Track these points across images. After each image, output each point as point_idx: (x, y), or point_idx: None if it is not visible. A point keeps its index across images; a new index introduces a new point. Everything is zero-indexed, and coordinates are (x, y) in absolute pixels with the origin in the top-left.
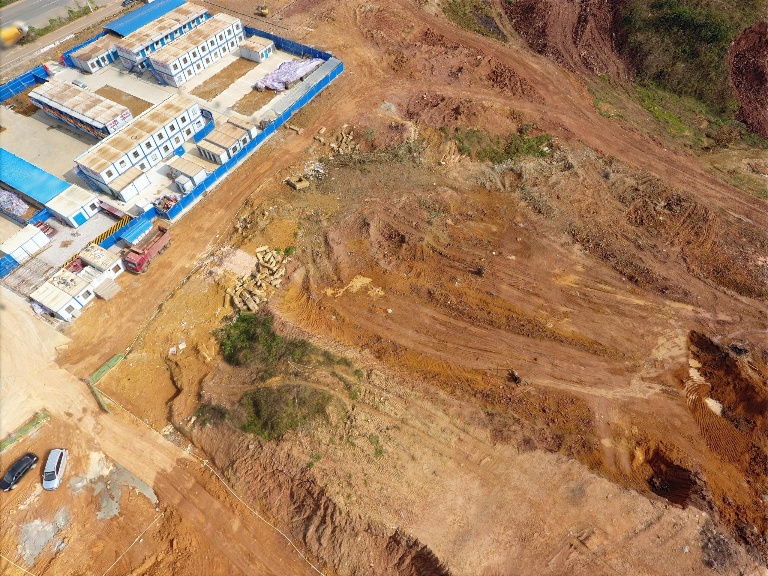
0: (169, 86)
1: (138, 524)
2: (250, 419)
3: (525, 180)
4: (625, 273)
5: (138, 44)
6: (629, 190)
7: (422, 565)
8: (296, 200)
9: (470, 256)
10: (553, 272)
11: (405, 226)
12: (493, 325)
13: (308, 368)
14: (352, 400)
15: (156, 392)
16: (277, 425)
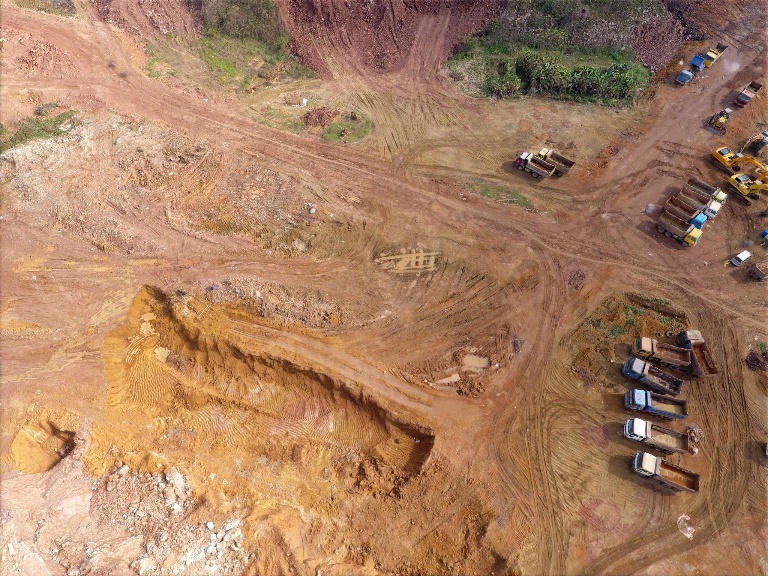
0: None
1: None
2: None
3: (19, 167)
4: (95, 243)
5: None
6: (133, 153)
7: None
8: None
9: None
10: (16, 261)
11: None
12: None
13: None
14: None
15: None
16: None
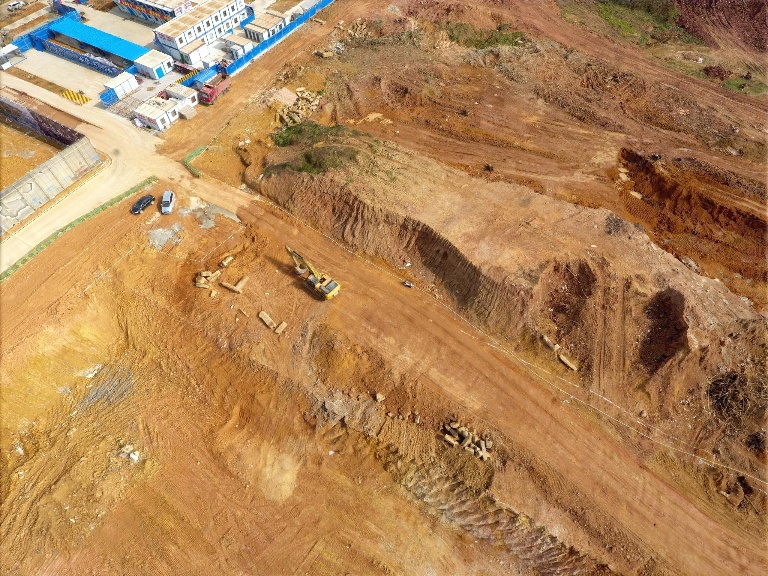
0: None
1: (229, 230)
2: (304, 164)
3: (502, 59)
4: (576, 115)
5: None
6: (583, 65)
7: (422, 242)
8: (323, 64)
9: (458, 104)
10: (521, 114)
11: (408, 83)
12: (474, 140)
13: (342, 138)
14: (373, 154)
15: (231, 168)
16: (323, 163)
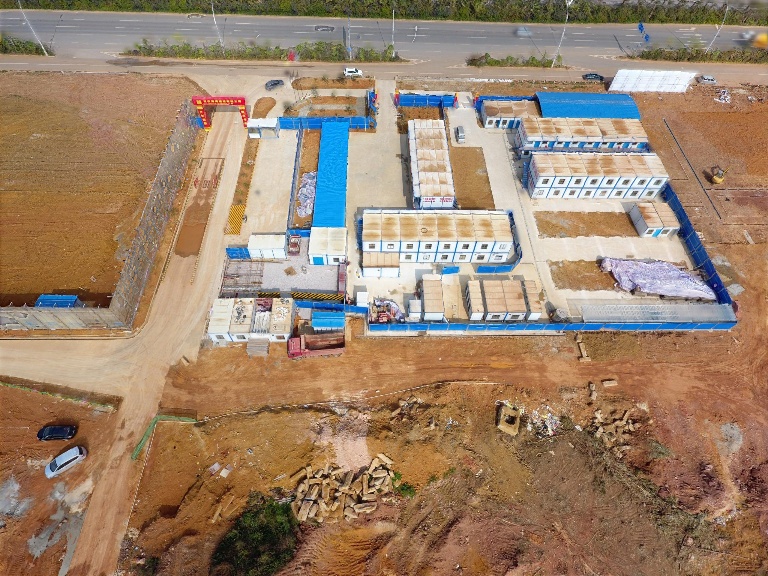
0: (526, 190)
1: None
2: None
3: None
4: None
5: (540, 134)
6: None
7: None
8: (483, 437)
9: None
10: None
11: None
12: None
13: None
14: None
15: (170, 486)
16: None
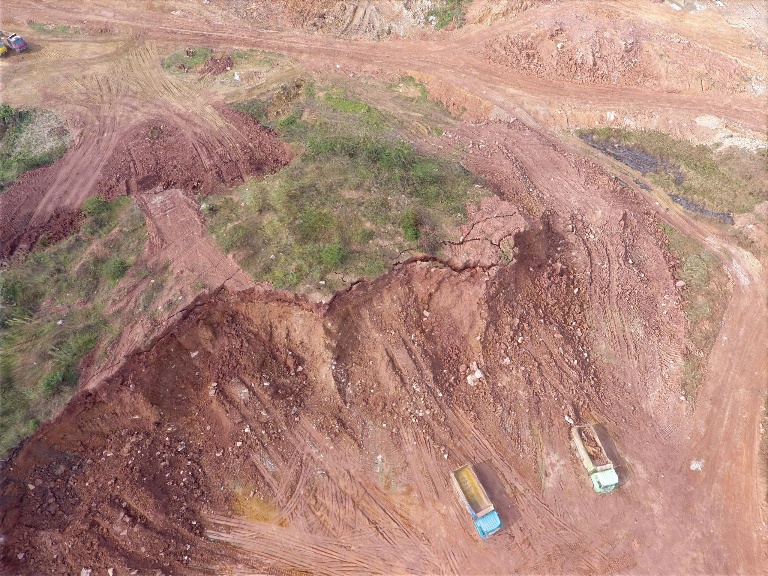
0: None
1: None
2: None
3: None
4: None
5: None
6: (356, 3)
7: None
8: None
9: None
10: None
11: None
12: None
13: None
14: None
15: None
16: None
